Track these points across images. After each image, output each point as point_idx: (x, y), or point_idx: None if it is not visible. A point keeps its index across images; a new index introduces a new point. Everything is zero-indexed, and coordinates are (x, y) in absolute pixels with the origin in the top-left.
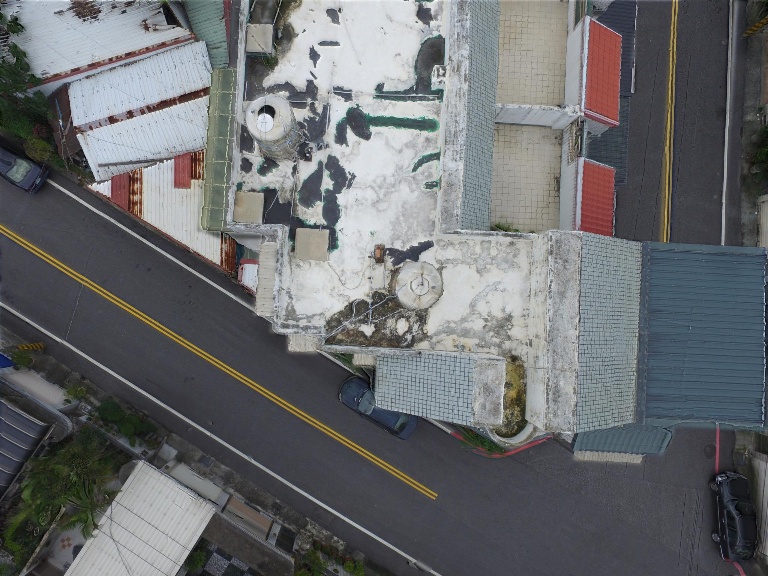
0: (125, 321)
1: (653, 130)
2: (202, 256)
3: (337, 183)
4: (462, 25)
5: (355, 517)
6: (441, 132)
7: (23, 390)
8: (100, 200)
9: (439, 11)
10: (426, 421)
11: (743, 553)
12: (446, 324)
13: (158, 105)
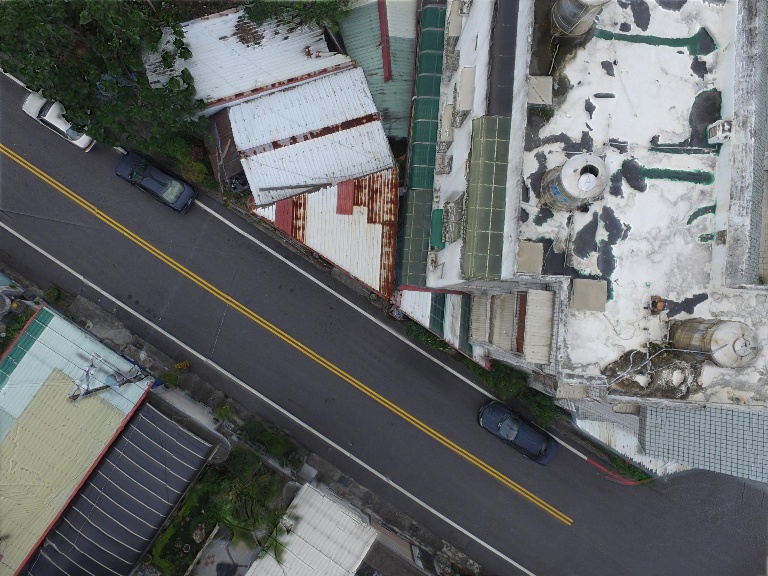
0: (268, 341)
1: None
2: (361, 281)
3: (612, 234)
4: (746, 81)
5: (491, 541)
6: (719, 186)
7: (184, 410)
8: (245, 221)
9: (714, 64)
10: (564, 447)
11: None
12: (721, 376)
13: (321, 131)
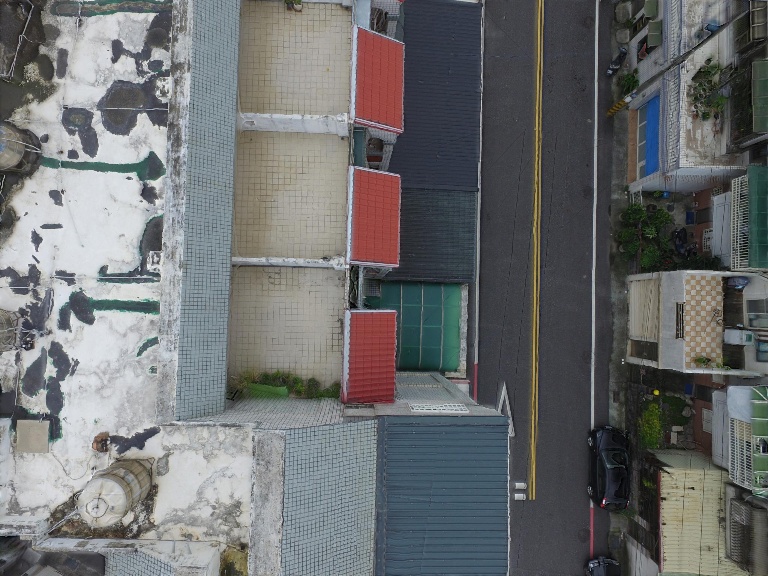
0: None
1: (521, 211)
2: None
3: (60, 370)
4: (177, 209)
5: None
6: None
7: None
8: None
9: (164, 189)
10: None
11: None
12: (173, 512)
13: None
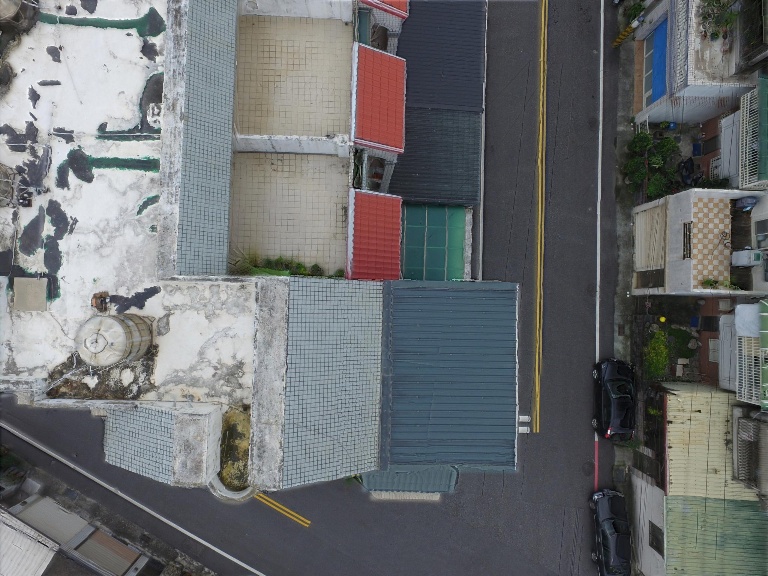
0: None
1: (525, 142)
2: None
3: (59, 229)
4: (178, 61)
5: (226, 547)
6: None
7: None
8: None
9: (164, 46)
10: None
11: (620, 573)
12: (174, 373)
13: None
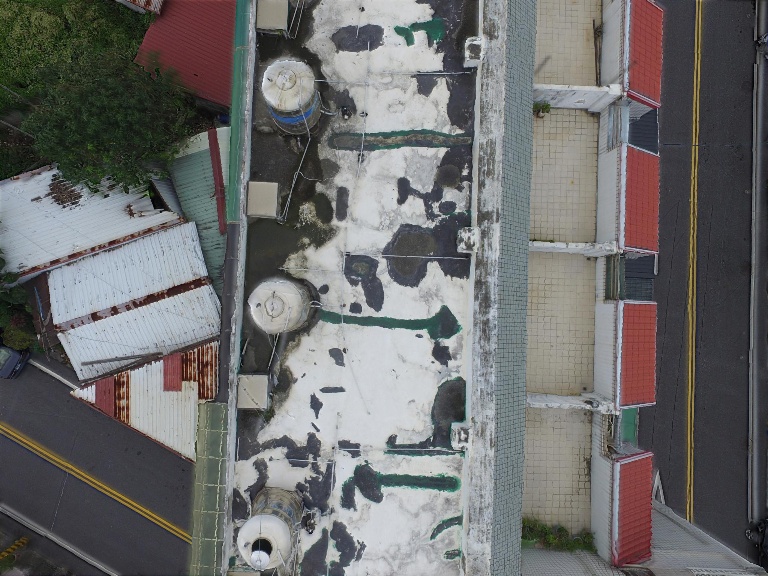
0: (114, 511)
1: (674, 287)
2: None
3: (344, 554)
4: (486, 379)
5: None
6: (463, 496)
7: None
8: None
9: (458, 349)
10: None
11: None
12: None
13: (145, 300)
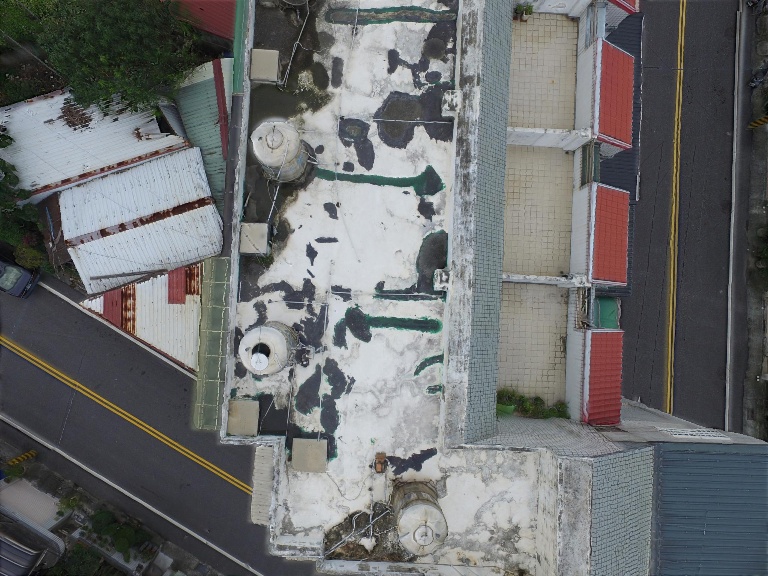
0: (119, 427)
1: (657, 223)
2: None
3: (336, 388)
4: (466, 227)
5: None
6: (444, 335)
7: (13, 512)
8: None
9: (441, 205)
10: None
11: None
12: (450, 536)
13: (151, 218)
